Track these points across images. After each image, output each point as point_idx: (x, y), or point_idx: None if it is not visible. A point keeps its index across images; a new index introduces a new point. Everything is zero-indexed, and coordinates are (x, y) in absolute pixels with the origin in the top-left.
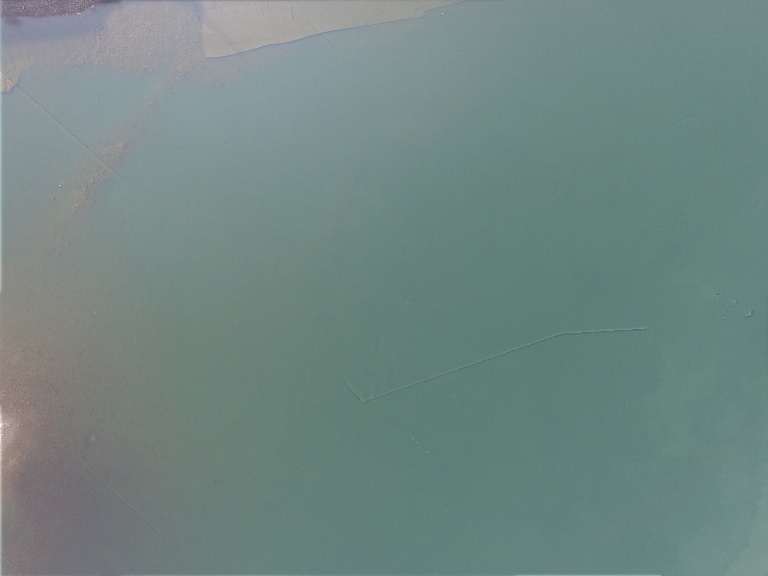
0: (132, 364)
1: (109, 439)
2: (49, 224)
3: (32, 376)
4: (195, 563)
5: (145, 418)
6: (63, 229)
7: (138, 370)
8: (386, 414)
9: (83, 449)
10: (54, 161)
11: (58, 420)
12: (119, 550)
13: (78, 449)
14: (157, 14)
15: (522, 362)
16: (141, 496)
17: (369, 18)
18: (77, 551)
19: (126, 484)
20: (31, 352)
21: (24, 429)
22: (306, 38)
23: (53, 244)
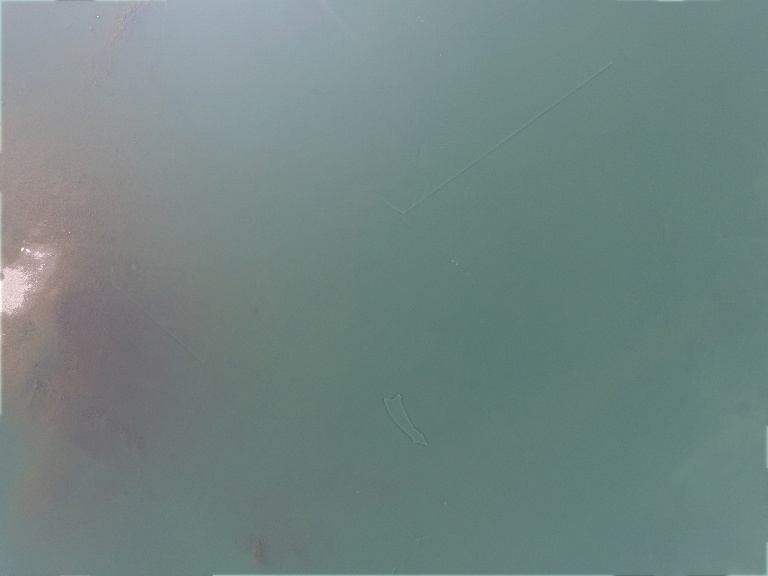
0: (171, 194)
1: (150, 268)
2: (88, 55)
3: (73, 206)
4: (235, 398)
5: (185, 247)
6: (102, 60)
7: (177, 199)
8: (426, 238)
9: (124, 278)
10: None
11: (99, 250)
12: (161, 379)
13: (119, 279)
14: None
15: (561, 188)
16: (182, 325)
17: None
18: (119, 380)
19: (167, 313)
20: (72, 182)
21: (66, 259)
22: None
23: (92, 75)
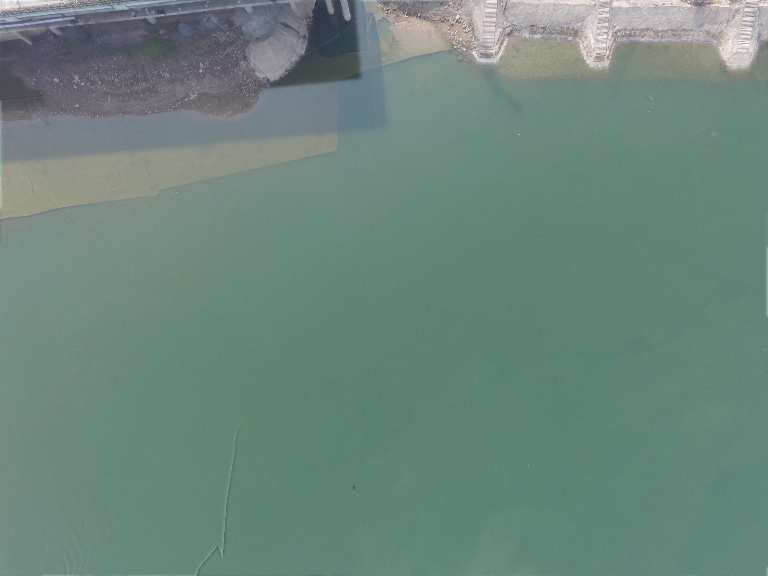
0: None
1: None
2: None
3: None
4: None
5: None
6: None
7: None
8: None
9: None
10: None
11: None
12: None
13: None
14: None
15: (249, 535)
16: None
17: (106, 195)
18: None
19: None
20: None
21: None
22: (45, 212)
23: None
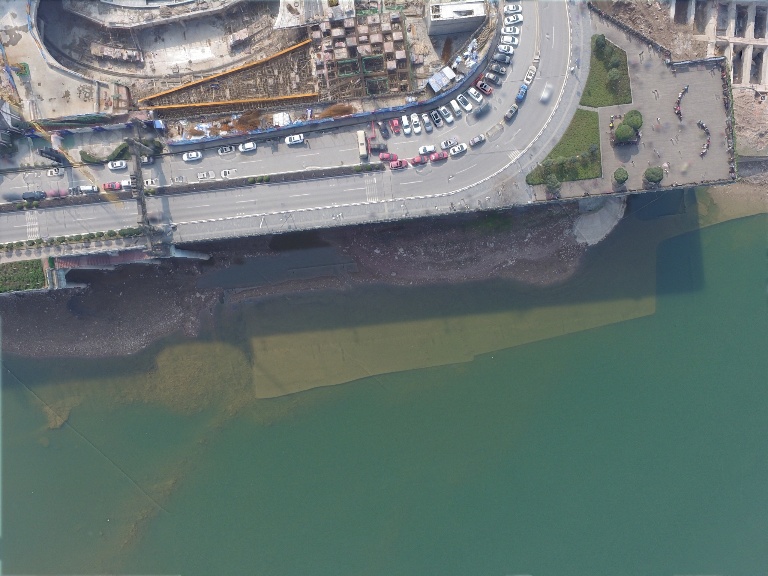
0: None
1: None
2: (97, 558)
3: None
4: None
5: None
6: (111, 563)
7: None
8: None
9: None
10: (103, 496)
11: None
12: None
13: None
14: (208, 354)
15: None
16: None
17: (419, 362)
18: None
19: None
20: None
21: None
22: (356, 380)
23: None
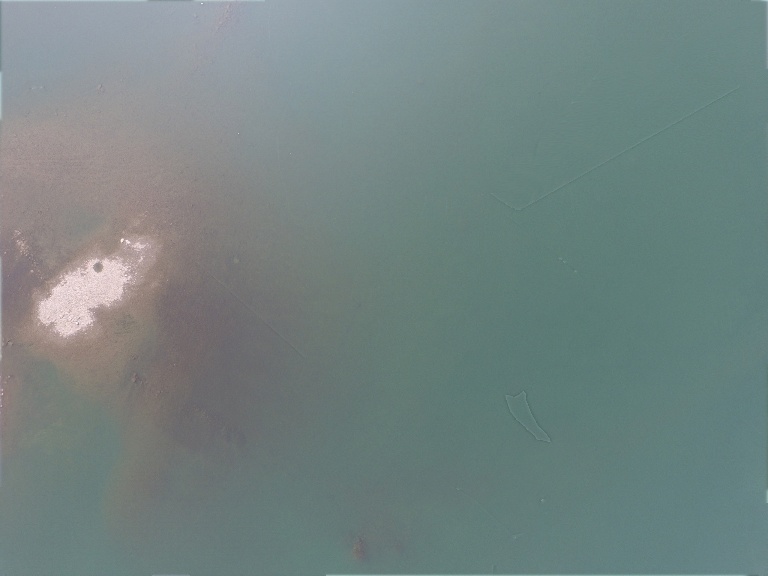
0: (275, 186)
1: (252, 262)
2: (191, 42)
3: (174, 197)
4: (333, 393)
5: (288, 240)
6: (205, 48)
7: (281, 192)
8: (533, 235)
9: (226, 271)
10: None
11: (201, 242)
12: (262, 373)
13: (221, 272)
14: None
15: (665, 187)
16: (284, 319)
17: None
18: (220, 375)
19: (269, 307)
20: (173, 173)
21: (166, 251)
22: None
23: (195, 63)
